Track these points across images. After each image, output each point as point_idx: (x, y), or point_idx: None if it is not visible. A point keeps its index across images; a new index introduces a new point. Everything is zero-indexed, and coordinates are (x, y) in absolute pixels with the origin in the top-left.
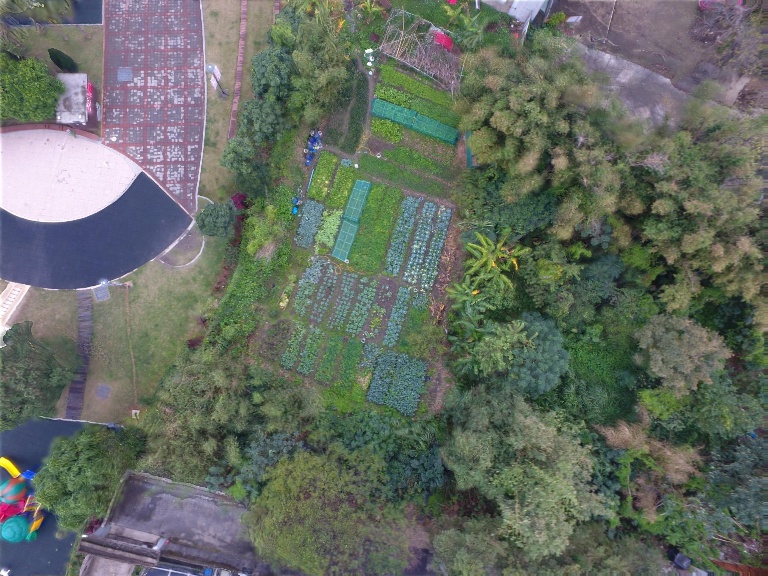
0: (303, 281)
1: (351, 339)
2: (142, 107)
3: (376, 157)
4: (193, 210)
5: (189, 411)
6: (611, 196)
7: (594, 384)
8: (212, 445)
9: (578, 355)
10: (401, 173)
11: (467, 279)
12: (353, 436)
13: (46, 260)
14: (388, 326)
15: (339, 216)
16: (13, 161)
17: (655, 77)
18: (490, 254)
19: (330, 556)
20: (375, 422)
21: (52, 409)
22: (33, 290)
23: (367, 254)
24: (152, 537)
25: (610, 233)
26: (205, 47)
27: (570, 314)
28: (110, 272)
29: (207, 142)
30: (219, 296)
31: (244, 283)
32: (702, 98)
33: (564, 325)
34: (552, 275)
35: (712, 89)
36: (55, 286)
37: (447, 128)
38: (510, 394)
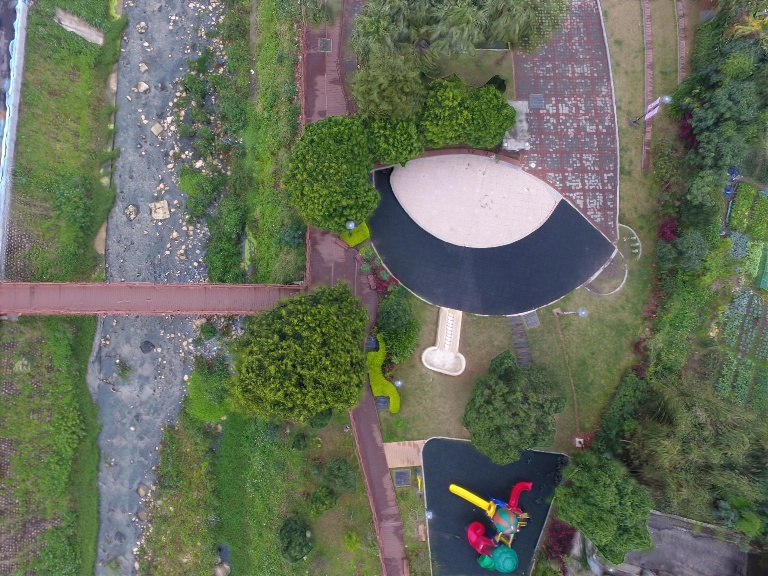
0: (731, 312)
1: None
2: (556, 134)
3: None
4: (615, 238)
5: (692, 444)
6: None
7: None
8: (725, 479)
9: None
10: None
11: None
12: None
13: (475, 286)
14: None
15: (761, 248)
16: (436, 185)
17: None
18: None
19: None
20: None
21: None
22: (465, 316)
23: None
24: (634, 568)
25: None
26: (612, 76)
27: None
28: (538, 299)
29: (622, 171)
30: (649, 325)
31: (683, 313)
32: None
33: None
34: None
35: None
36: (485, 312)
37: None
38: None
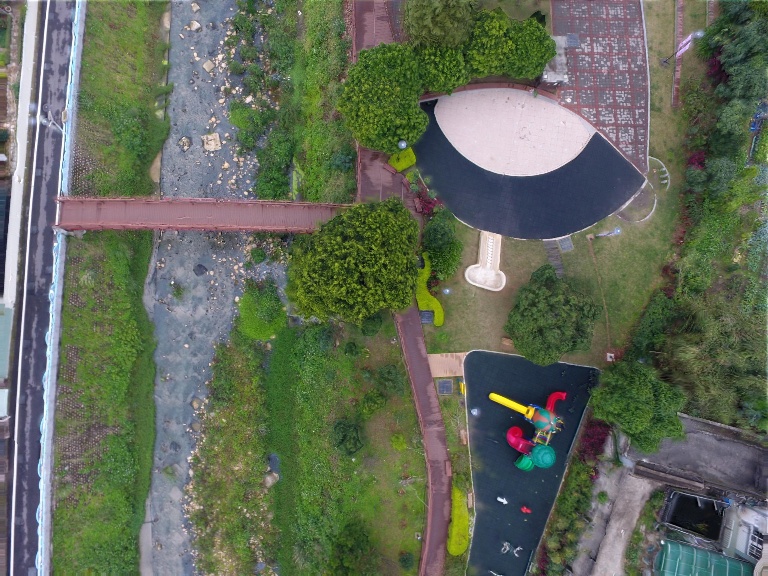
0: (753, 239)
1: None
2: (591, 71)
3: None
4: (646, 170)
5: (719, 350)
6: None
7: None
8: None
9: None
10: None
11: None
12: None
13: (514, 211)
14: None
15: None
16: (478, 117)
17: None
18: None
19: None
20: None
21: None
22: (504, 239)
23: None
24: None
25: None
26: (644, 18)
27: None
28: (573, 225)
29: (653, 107)
30: (677, 250)
31: (708, 238)
32: None
33: None
34: None
35: None
36: (523, 236)
37: None
38: None
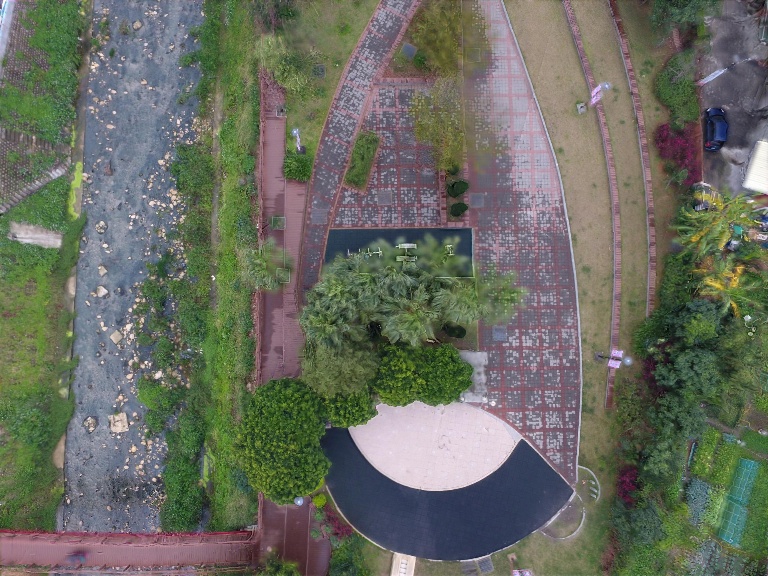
0: (687, 560)
1: None
2: (519, 369)
3: (757, 432)
4: (574, 481)
5: None
6: None
7: None
8: None
9: None
10: None
11: None
12: None
13: (430, 530)
14: None
15: (722, 494)
16: (394, 425)
17: None
18: None
19: None
20: None
21: None
22: (418, 562)
23: (748, 533)
24: None
25: None
26: (579, 306)
27: None
28: (493, 544)
29: (585, 408)
30: (604, 573)
31: (637, 567)
32: None
33: None
34: None
35: None
36: (439, 557)
37: None
38: None
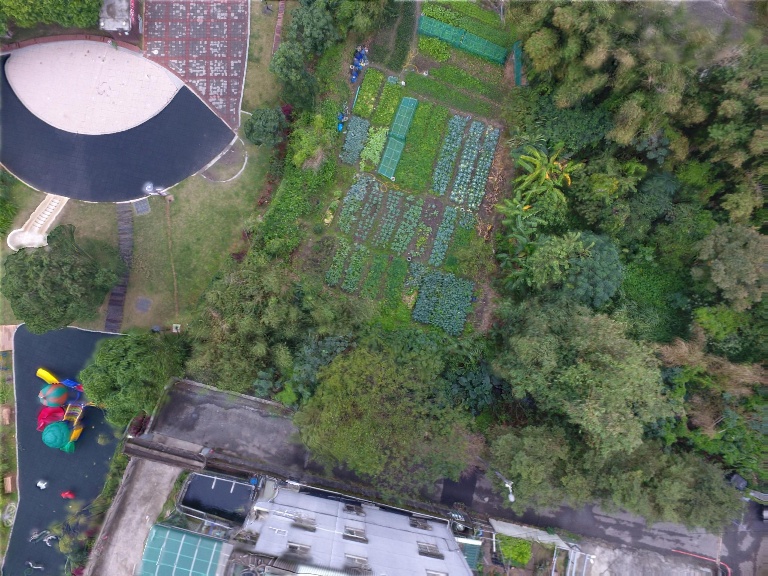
0: (348, 198)
1: (396, 257)
2: (184, 21)
3: (423, 75)
4: (236, 125)
5: (237, 315)
6: (674, 100)
7: (645, 305)
8: (261, 348)
9: (628, 276)
10: (448, 92)
11: (518, 194)
12: (400, 352)
13: (85, 172)
14: (434, 245)
15: (385, 133)
16: (52, 72)
17: (707, 2)
18: (544, 166)
19: (388, 451)
20: (422, 339)
21: (91, 321)
22: (72, 202)
23: (413, 172)
24: (195, 447)
25: (667, 145)
26: None
27: (625, 228)
28: None
29: (251, 57)
30: (262, 212)
31: (289, 197)
32: (754, 24)
33: (617, 241)
34: (607, 187)
35: (764, 15)
36: (94, 199)
37: (496, 47)
38: (566, 303)
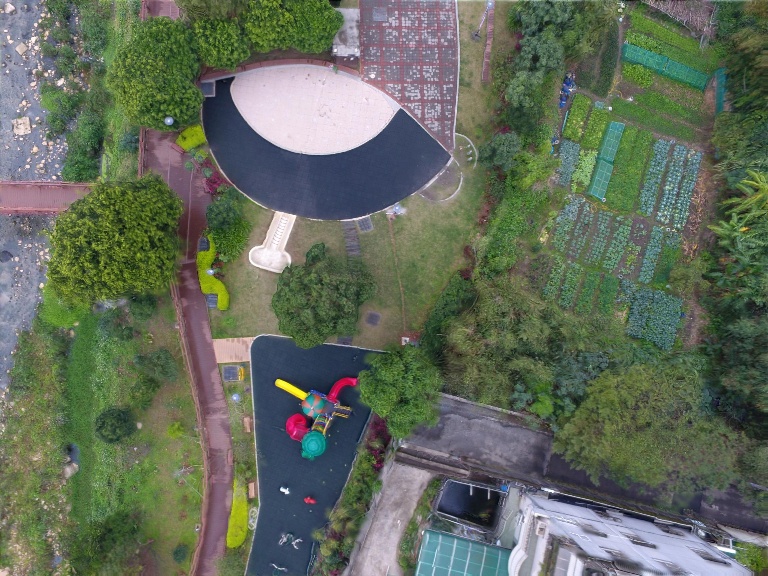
0: (562, 218)
1: (608, 275)
2: (398, 46)
3: (628, 100)
4: (451, 147)
5: (492, 331)
6: None
7: None
8: None
9: None
10: (652, 117)
11: (734, 216)
12: None
13: (311, 191)
14: (644, 263)
15: (595, 156)
16: (276, 95)
17: None
18: (766, 191)
19: None
20: (641, 353)
21: None
22: (299, 220)
23: (622, 193)
24: None
25: None
26: None
27: None
28: (373, 205)
29: (462, 82)
30: (480, 230)
31: (510, 217)
32: None
33: None
34: None
35: None
36: (320, 217)
37: (697, 74)
38: None
